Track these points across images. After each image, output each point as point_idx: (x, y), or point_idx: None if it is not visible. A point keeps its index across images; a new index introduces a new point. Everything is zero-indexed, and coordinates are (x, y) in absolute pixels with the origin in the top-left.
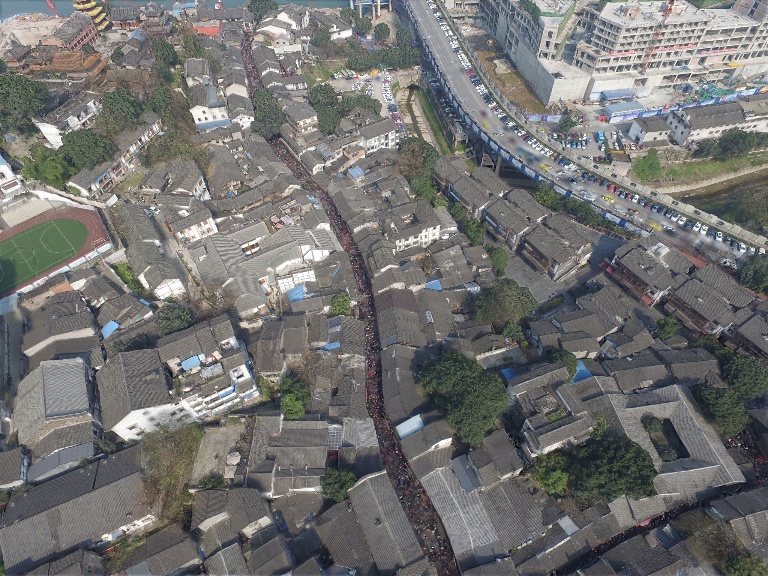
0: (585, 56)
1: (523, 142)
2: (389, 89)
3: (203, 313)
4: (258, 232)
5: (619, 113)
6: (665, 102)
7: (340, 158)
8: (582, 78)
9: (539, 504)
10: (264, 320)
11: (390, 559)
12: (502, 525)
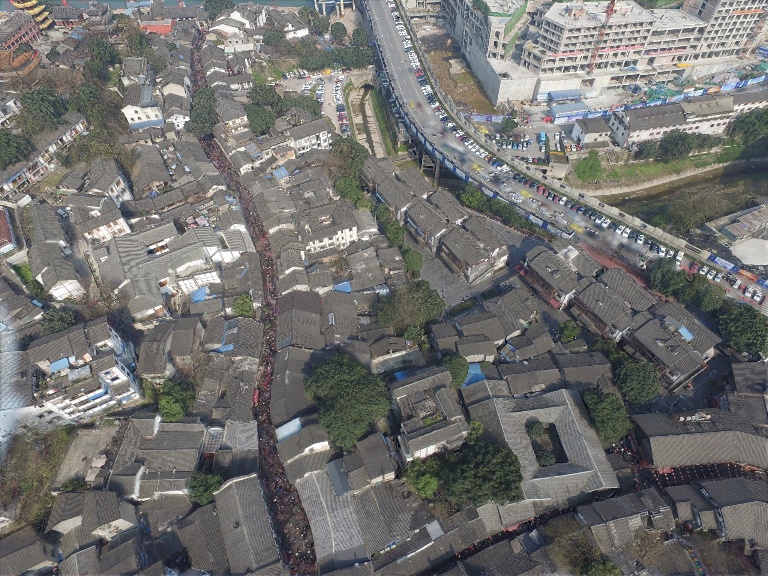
0: (531, 56)
1: (460, 143)
2: (340, 89)
3: (87, 315)
4: (166, 233)
5: (563, 114)
6: (613, 103)
7: (269, 159)
8: (529, 78)
9: (410, 508)
10: (159, 322)
11: (242, 563)
12: (368, 529)
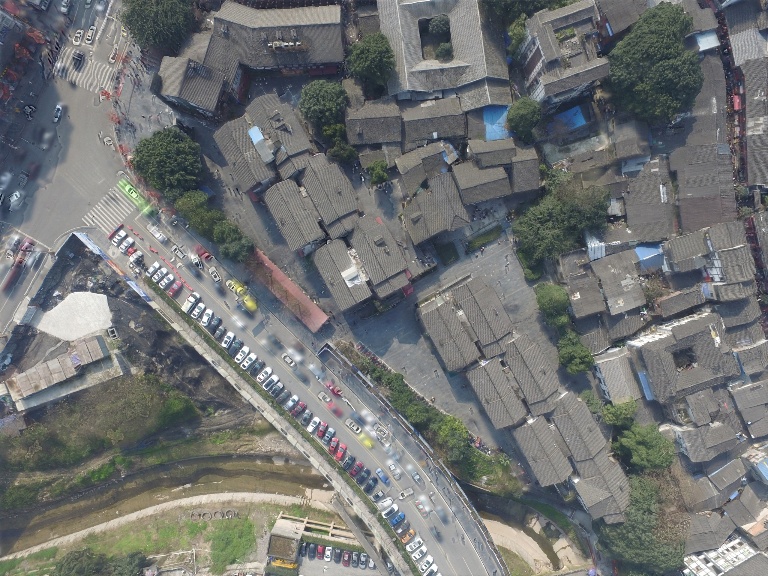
0: None
1: None
2: None
3: None
4: None
5: None
6: None
7: None
8: None
9: None
10: None
11: None
12: None
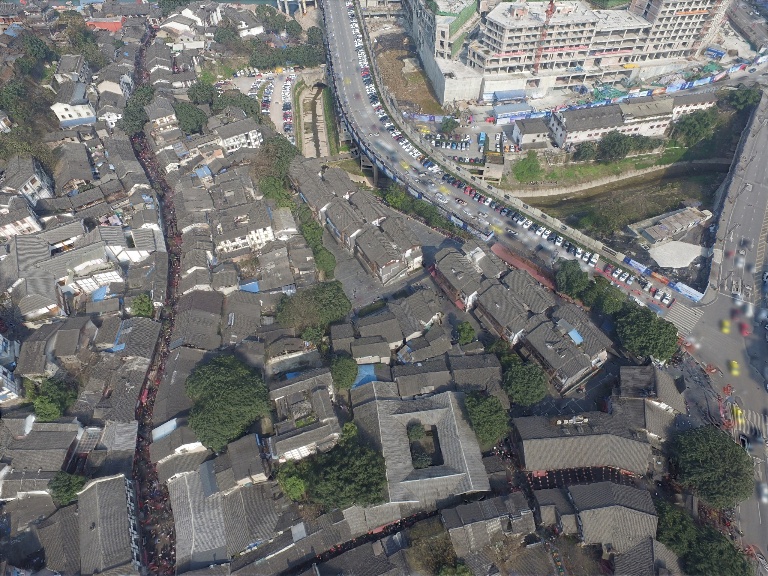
0: (476, 56)
1: (395, 143)
2: (289, 87)
3: None
4: (72, 232)
5: (506, 114)
6: (559, 103)
7: (195, 157)
8: (473, 78)
9: (279, 510)
10: (52, 321)
11: (92, 564)
12: (232, 531)
